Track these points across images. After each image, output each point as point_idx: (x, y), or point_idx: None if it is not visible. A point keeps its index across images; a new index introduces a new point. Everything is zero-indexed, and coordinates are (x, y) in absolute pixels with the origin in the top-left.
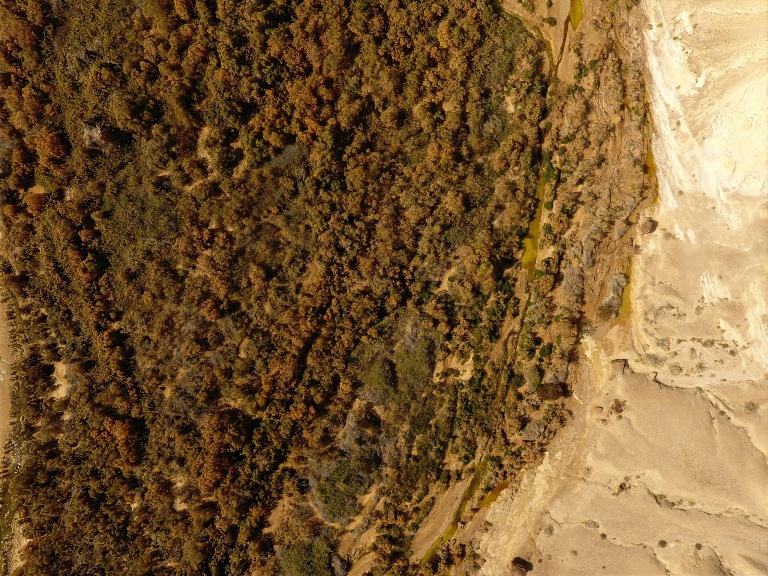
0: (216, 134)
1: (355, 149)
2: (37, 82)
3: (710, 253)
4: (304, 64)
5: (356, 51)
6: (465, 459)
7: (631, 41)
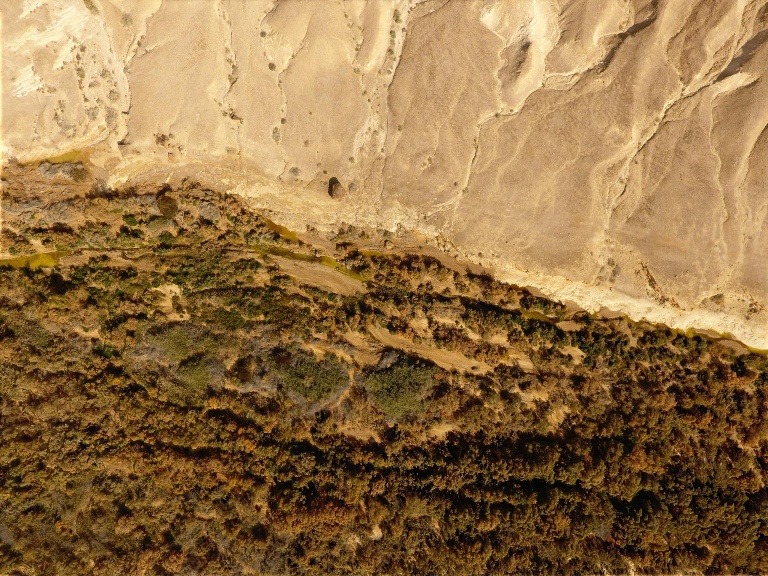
0: None
1: None
2: None
3: None
4: None
5: None
6: (253, 268)
7: None
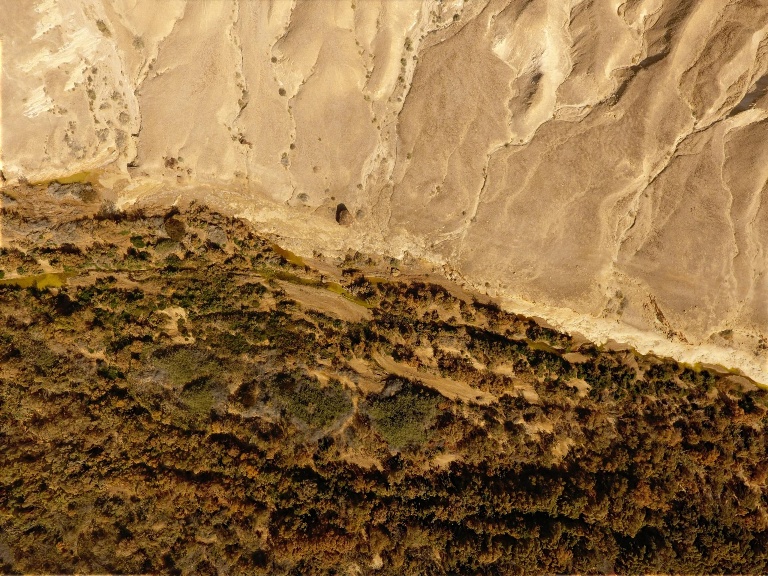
0: None
1: None
2: None
3: (4, 115)
4: None
5: None
6: (259, 293)
7: None
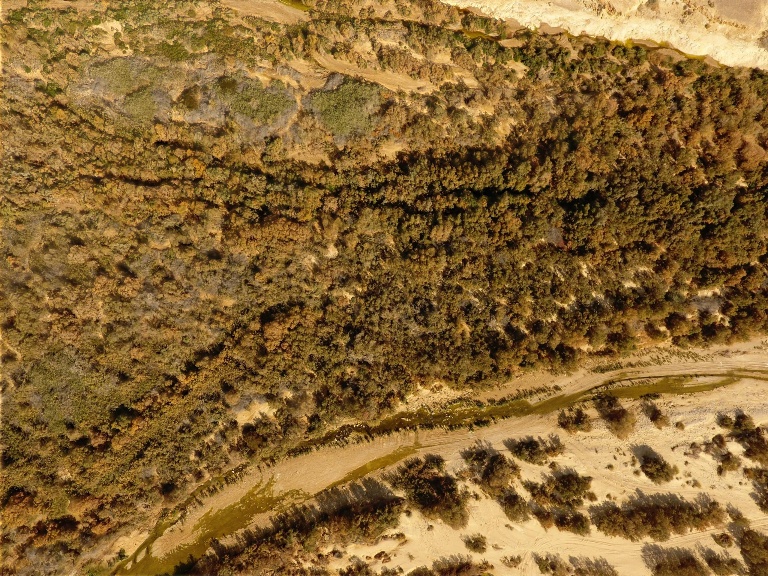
0: None
1: None
2: None
3: None
4: None
5: None
6: (194, 0)
7: None
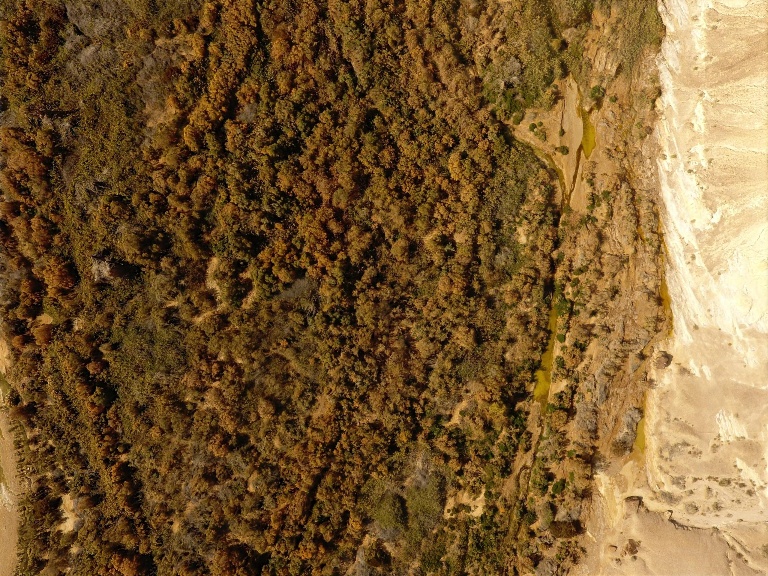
0: (225, 269)
1: (365, 285)
2: (46, 212)
3: (726, 391)
4: (314, 196)
5: (366, 181)
6: None
7: (645, 170)
